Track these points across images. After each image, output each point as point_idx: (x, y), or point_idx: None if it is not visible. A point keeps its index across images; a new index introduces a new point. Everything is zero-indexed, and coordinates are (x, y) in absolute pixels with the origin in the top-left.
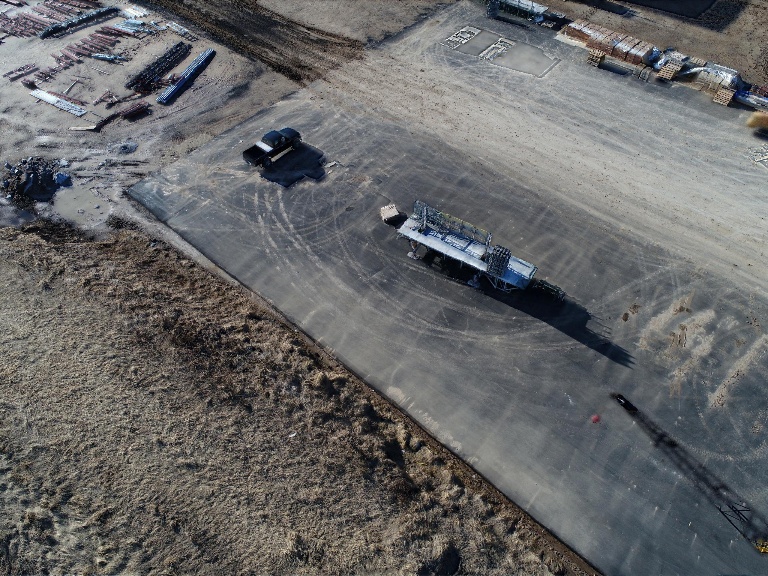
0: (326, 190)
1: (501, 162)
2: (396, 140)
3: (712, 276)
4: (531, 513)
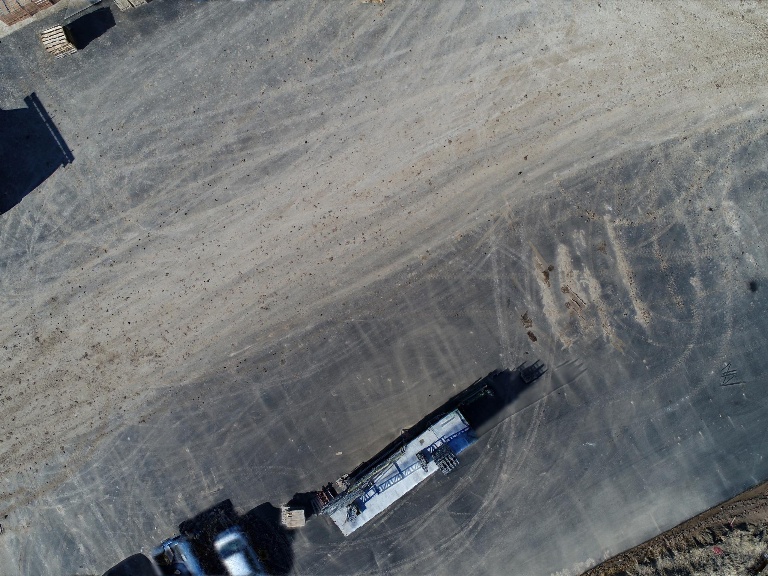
0: (218, 573)
1: (251, 333)
2: (150, 449)
3: (523, 211)
4: (664, 531)
